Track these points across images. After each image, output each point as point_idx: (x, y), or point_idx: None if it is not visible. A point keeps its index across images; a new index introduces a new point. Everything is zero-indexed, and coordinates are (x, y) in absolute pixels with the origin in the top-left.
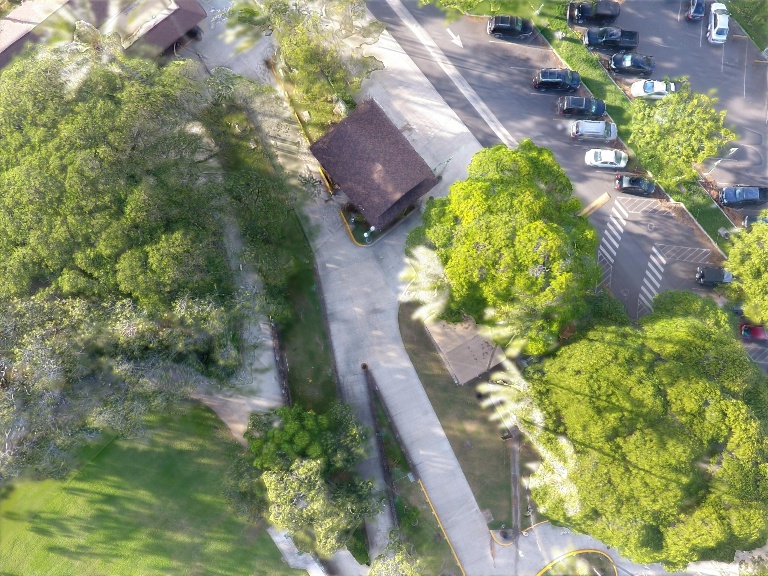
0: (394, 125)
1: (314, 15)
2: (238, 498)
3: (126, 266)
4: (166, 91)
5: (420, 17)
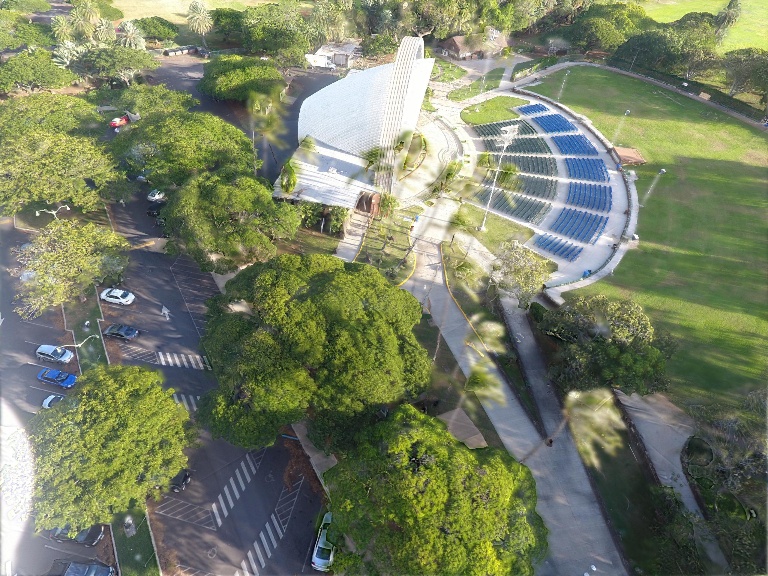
0: None
1: None
2: None
3: None
4: None
5: None
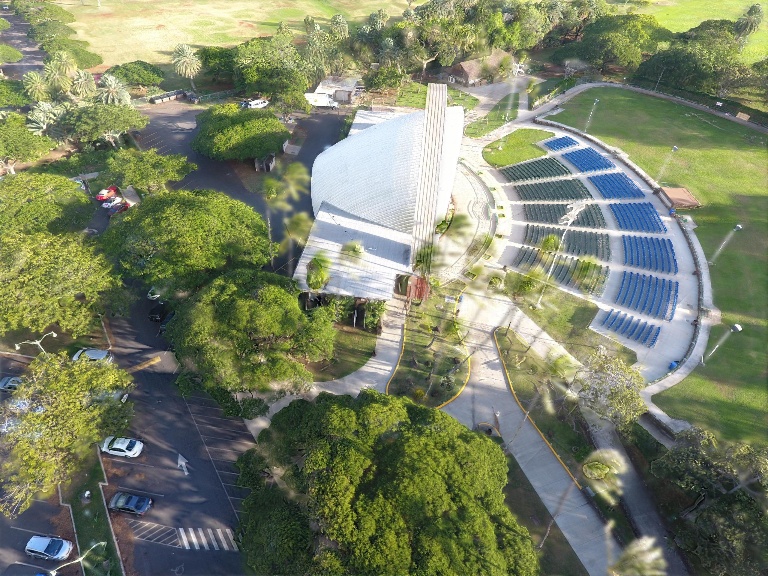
0: None
1: None
2: None
3: None
4: None
5: None
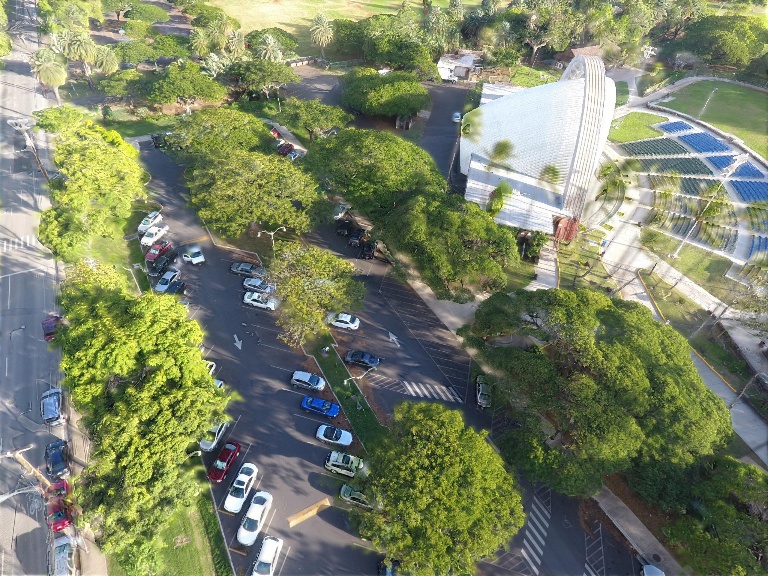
0: None
1: None
2: None
3: None
4: None
5: None
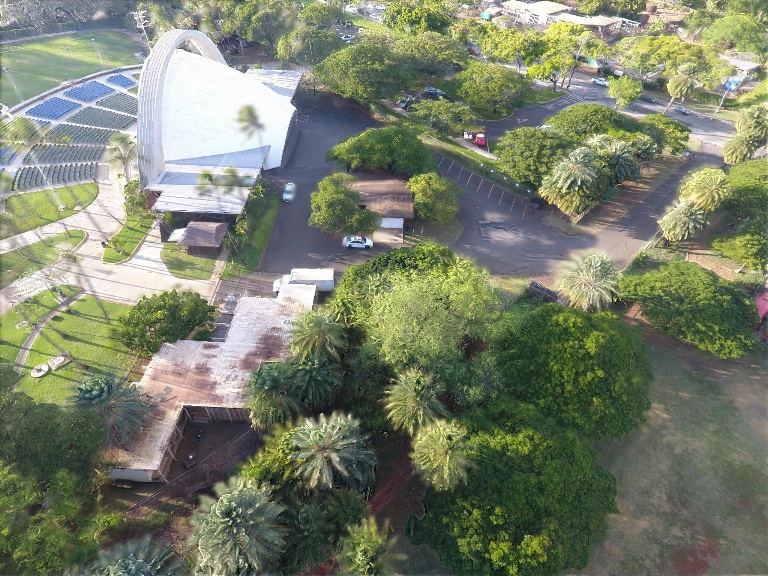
0: None
1: None
2: None
3: None
4: None
5: None
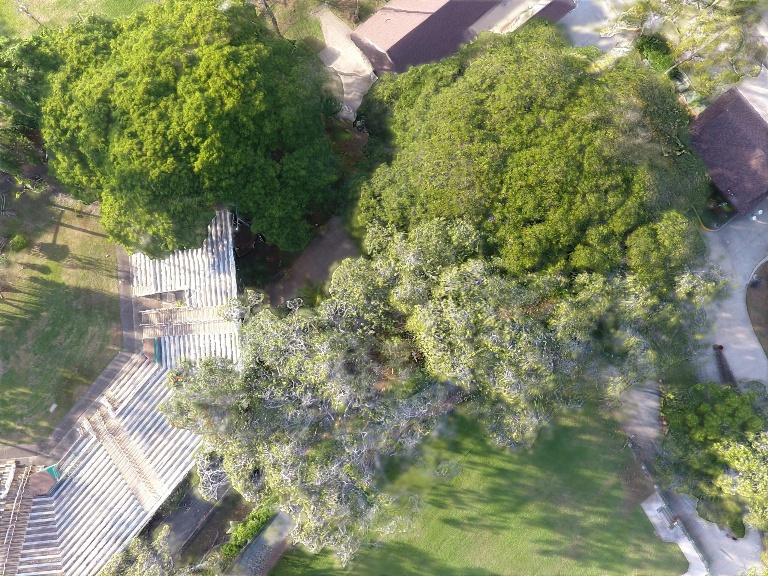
0: (758, 113)
1: (721, 5)
2: (673, 469)
3: (641, 242)
4: (639, 76)
5: (758, 9)
